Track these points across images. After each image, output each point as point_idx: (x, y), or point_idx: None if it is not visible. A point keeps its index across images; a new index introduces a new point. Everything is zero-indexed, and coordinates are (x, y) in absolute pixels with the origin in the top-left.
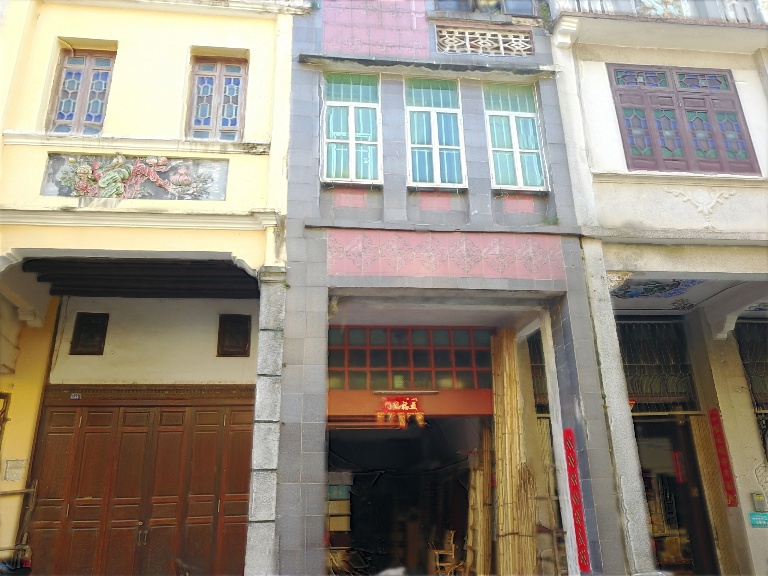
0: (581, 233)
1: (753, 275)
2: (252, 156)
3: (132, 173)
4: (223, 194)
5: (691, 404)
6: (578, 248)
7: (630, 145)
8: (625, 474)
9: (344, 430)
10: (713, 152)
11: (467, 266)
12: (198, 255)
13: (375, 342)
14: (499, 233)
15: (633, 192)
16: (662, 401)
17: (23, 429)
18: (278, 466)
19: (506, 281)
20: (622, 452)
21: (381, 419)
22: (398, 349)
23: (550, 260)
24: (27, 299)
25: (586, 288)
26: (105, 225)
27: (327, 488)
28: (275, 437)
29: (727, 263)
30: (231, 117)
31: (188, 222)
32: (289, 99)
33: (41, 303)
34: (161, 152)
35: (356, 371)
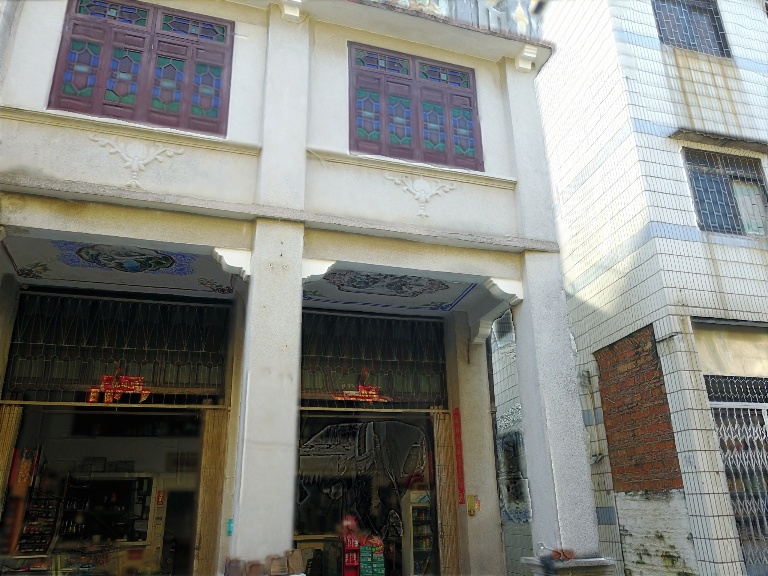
0: None
1: (176, 245)
2: None
3: None
4: None
5: (219, 397)
6: None
7: (64, 81)
8: None
9: None
10: (175, 105)
11: None
12: None
13: None
14: None
15: (43, 134)
16: (186, 392)
17: None
18: None
19: None
20: None
21: None
22: None
23: None
24: None
25: None
26: None
27: None
28: None
29: (140, 228)
30: None
31: None
32: None
33: None
34: None
35: None
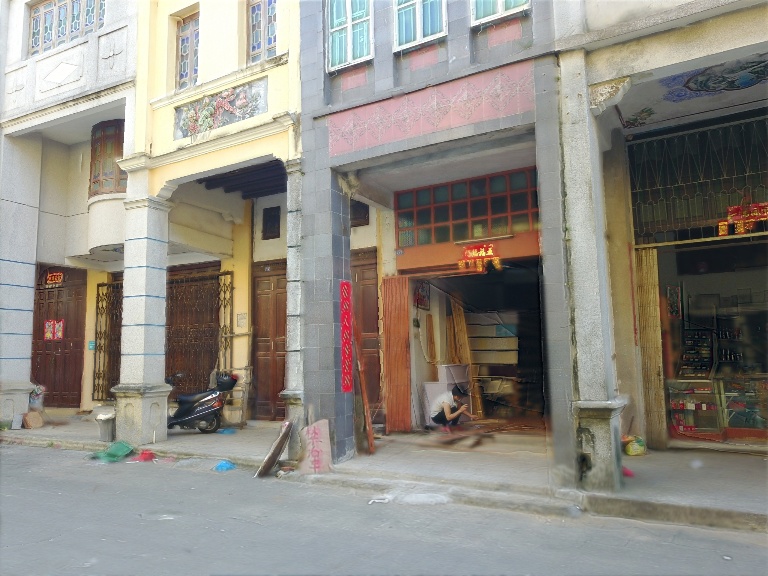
0: (554, 49)
1: None
2: (281, 67)
3: (216, 108)
4: (266, 107)
5: None
6: (553, 68)
7: None
8: (579, 307)
9: (445, 278)
10: None
11: (437, 120)
12: (259, 160)
13: (457, 196)
14: (468, 76)
15: None
16: None
17: (242, 294)
18: (300, 313)
19: (472, 126)
20: (578, 285)
21: (462, 266)
22: (476, 199)
23: (519, 91)
24: (221, 207)
25: (558, 113)
26: (205, 153)
27: (332, 327)
28: (298, 292)
29: None
30: (273, 35)
31: (245, 137)
32: (299, 4)
33: (236, 207)
34: (228, 85)
35: (440, 226)
